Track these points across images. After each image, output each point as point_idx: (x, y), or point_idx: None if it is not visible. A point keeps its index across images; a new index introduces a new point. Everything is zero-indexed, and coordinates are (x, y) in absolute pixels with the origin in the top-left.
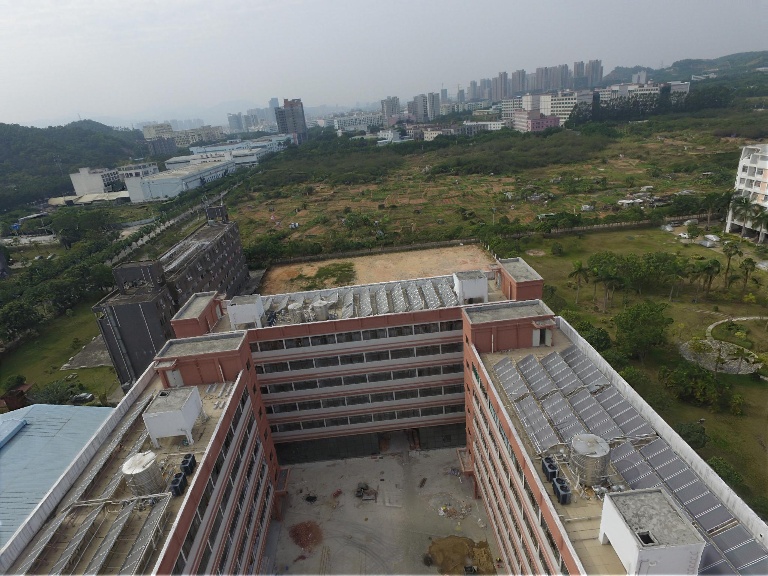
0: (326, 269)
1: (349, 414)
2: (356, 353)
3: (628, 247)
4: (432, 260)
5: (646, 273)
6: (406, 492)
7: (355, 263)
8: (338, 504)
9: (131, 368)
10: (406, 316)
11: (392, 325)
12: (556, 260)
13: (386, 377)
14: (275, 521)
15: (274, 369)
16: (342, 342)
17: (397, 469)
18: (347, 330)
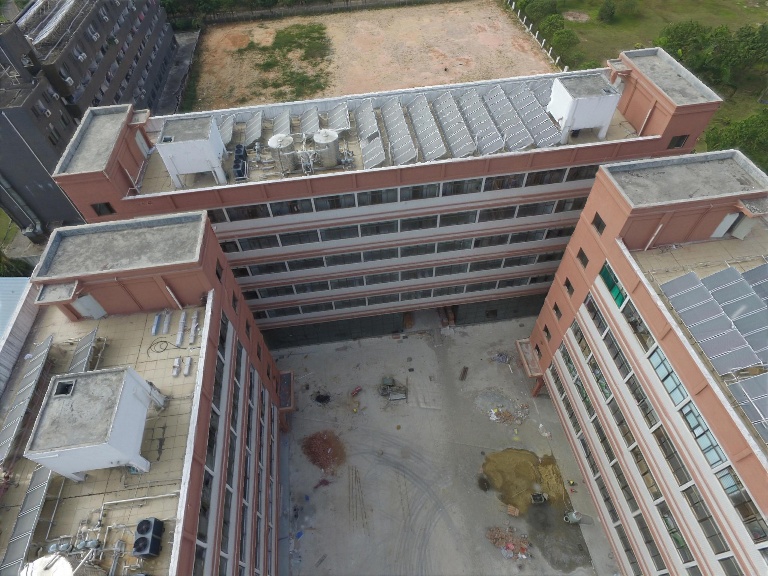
0: (287, 34)
1: (368, 295)
2: (386, 220)
3: (699, 11)
4: (436, 23)
5: (743, 59)
6: (444, 388)
7: (327, 25)
8: (359, 406)
9: (27, 208)
10: (477, 164)
11: (451, 178)
12: (605, 30)
13: (427, 250)
14: (280, 433)
15: (255, 245)
16: (365, 205)
17: (428, 354)
18: (376, 187)
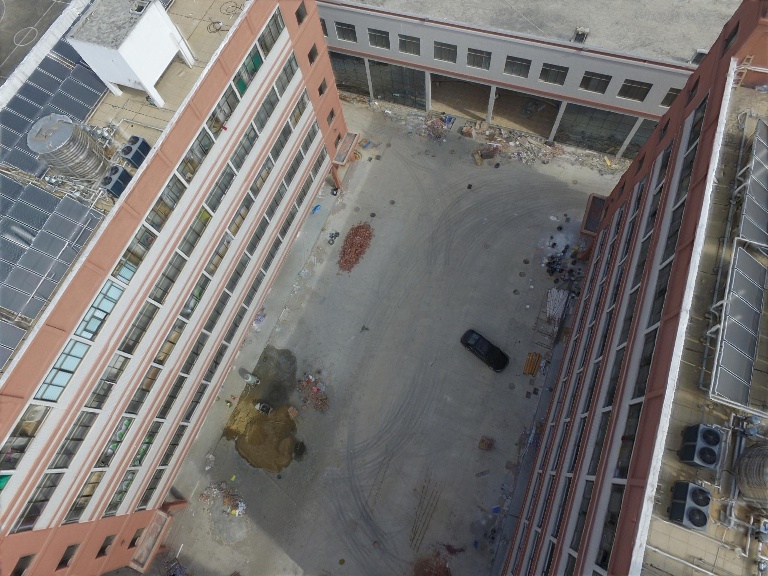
0: None
1: None
2: None
3: None
4: None
5: None
6: None
7: None
8: None
9: None
10: None
11: None
12: None
13: None
14: None
15: None
16: None
17: None
18: None
